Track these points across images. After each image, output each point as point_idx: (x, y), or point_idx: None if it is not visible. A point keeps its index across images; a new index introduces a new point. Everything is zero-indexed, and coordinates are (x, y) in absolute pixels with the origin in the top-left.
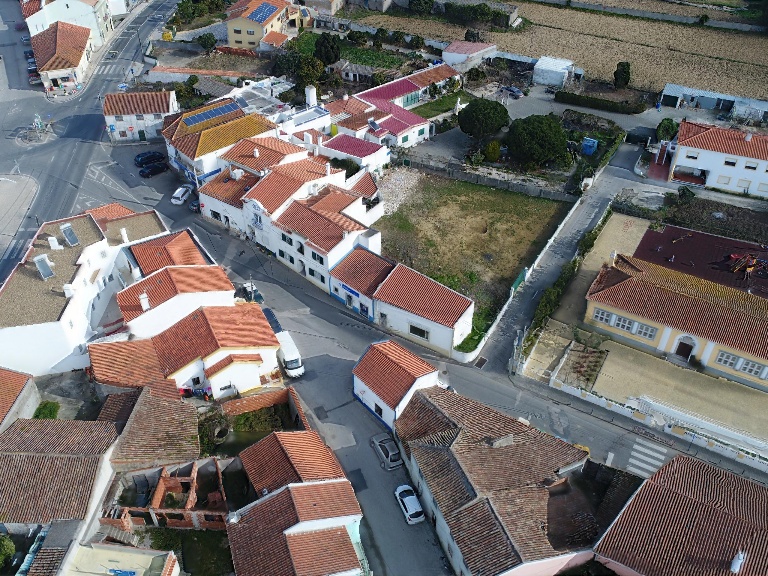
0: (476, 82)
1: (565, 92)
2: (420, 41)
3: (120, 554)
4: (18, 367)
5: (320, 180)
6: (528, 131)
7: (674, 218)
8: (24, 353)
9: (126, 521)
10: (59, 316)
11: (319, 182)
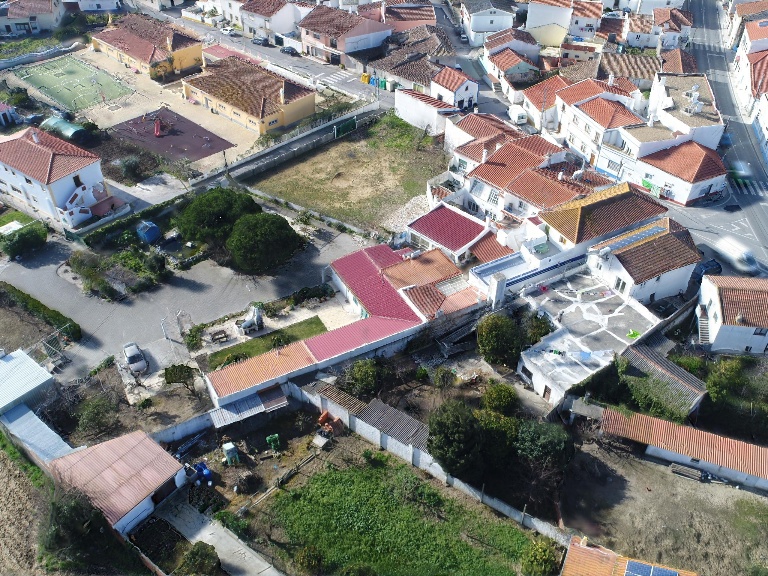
0: (169, 403)
1: (66, 322)
2: (199, 543)
3: None
4: None
5: None
6: (238, 195)
7: None
8: None
9: None
10: None
11: None
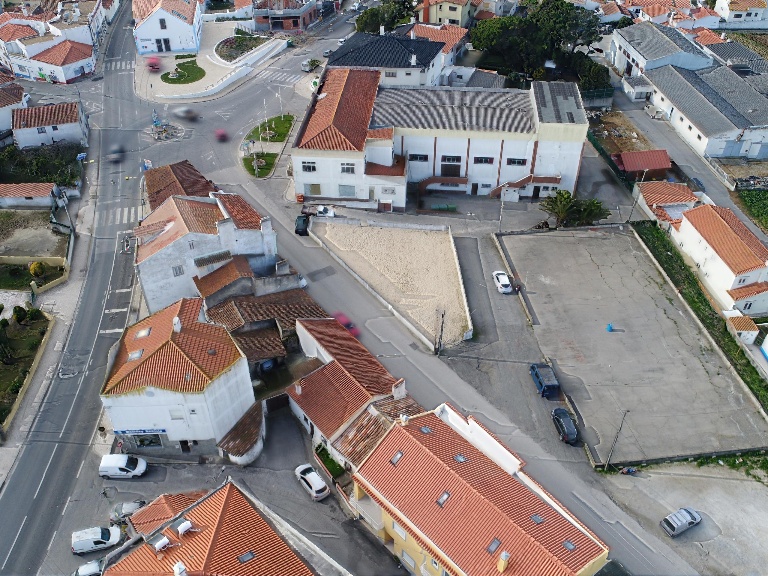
0: None
1: None
2: None
3: None
4: None
5: None
6: None
7: None
8: None
9: None
10: (65, 5)
11: None
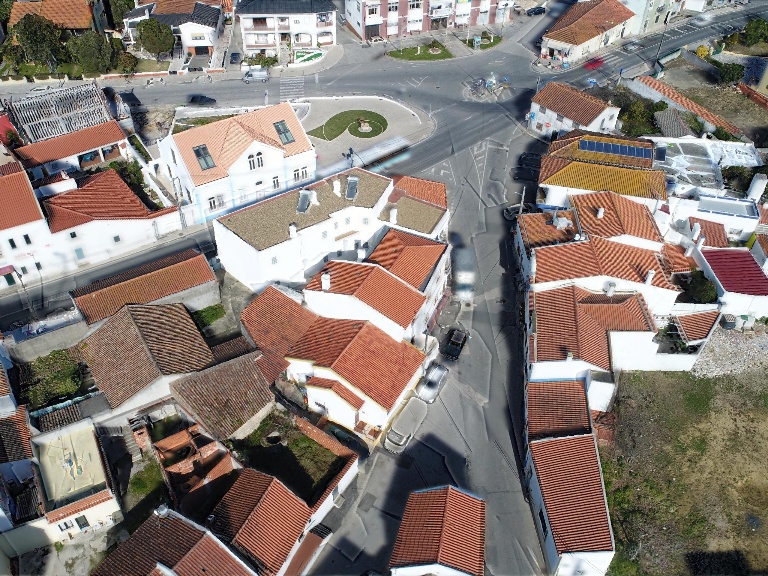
0: None
1: None
2: None
3: (98, 456)
4: (232, 266)
5: (629, 283)
6: None
7: None
8: (237, 259)
9: (141, 437)
10: (267, 247)
11: (626, 284)
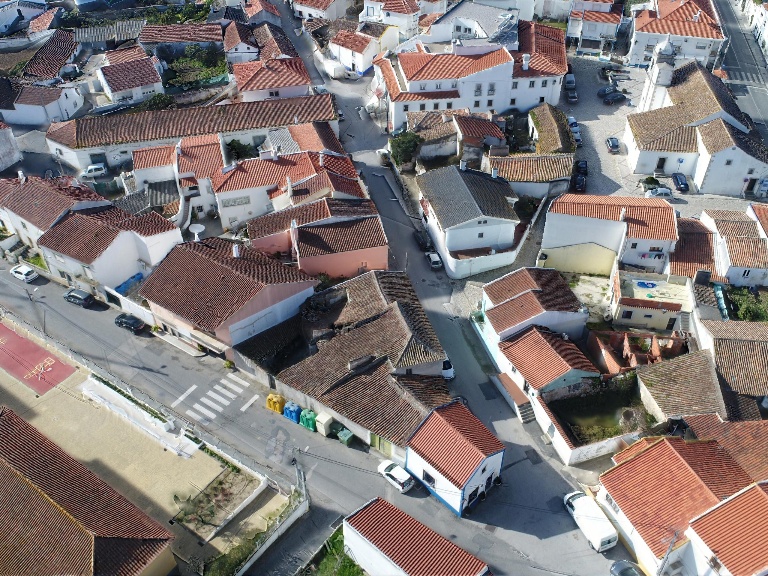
0: None
1: None
2: None
3: None
4: None
5: None
6: None
7: None
8: None
9: None
10: None
11: None
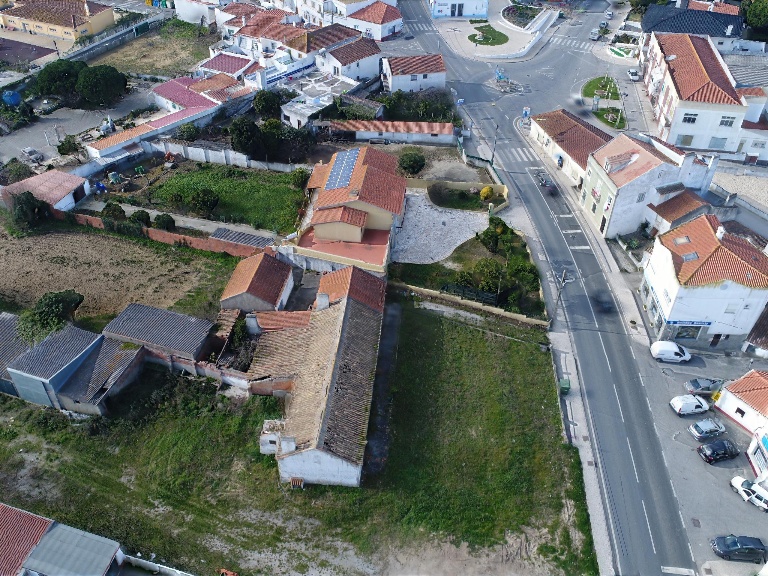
0: (65, 169)
1: None
2: None
3: None
4: None
5: None
6: None
7: (6, 60)
8: None
9: None
10: None
11: None
